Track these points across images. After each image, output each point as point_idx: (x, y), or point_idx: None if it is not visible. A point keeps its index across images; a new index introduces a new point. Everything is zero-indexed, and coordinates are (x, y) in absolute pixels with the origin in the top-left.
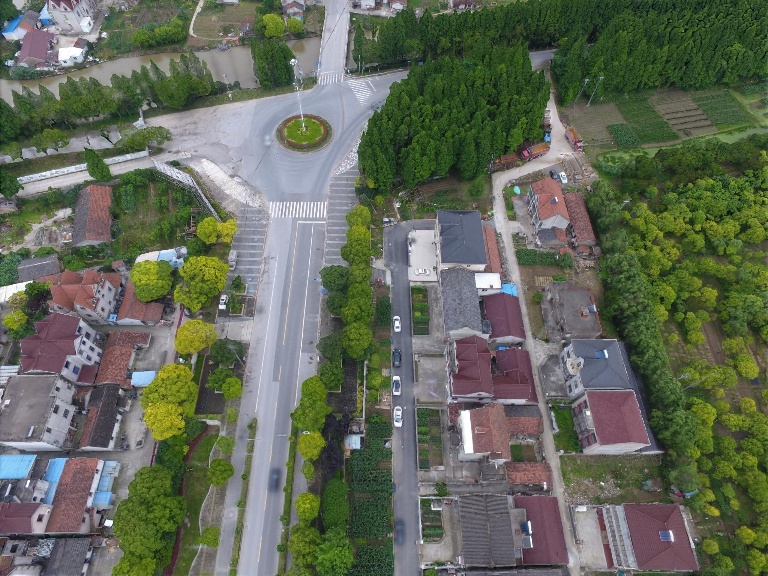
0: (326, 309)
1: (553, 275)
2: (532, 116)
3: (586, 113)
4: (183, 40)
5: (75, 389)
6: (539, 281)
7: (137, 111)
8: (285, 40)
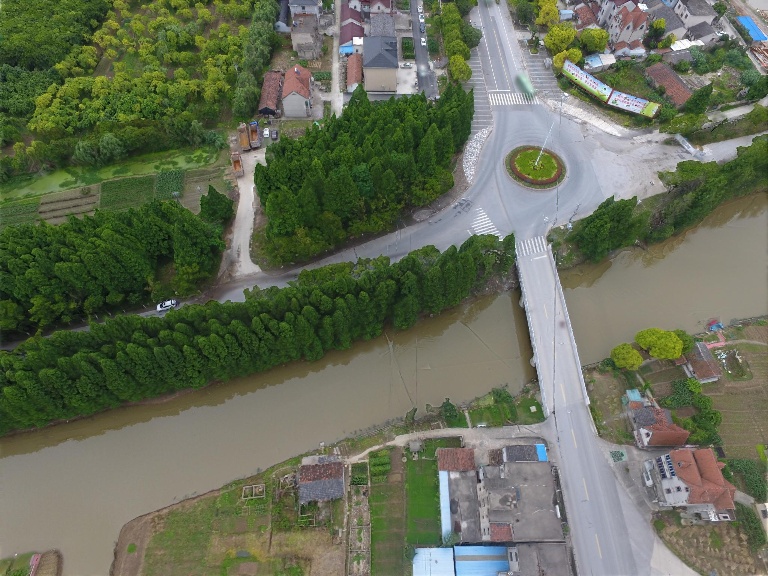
0: None
1: (306, 68)
2: None
3: None
4: None
5: (599, 5)
6: (318, 64)
7: None
8: None
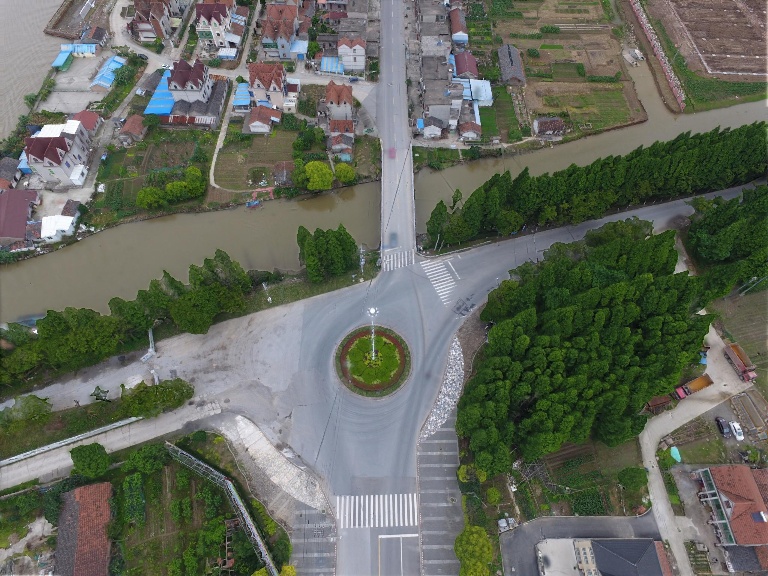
0: None
1: None
2: (694, 348)
3: (740, 306)
4: (202, 194)
5: None
6: None
7: (145, 333)
8: (332, 189)
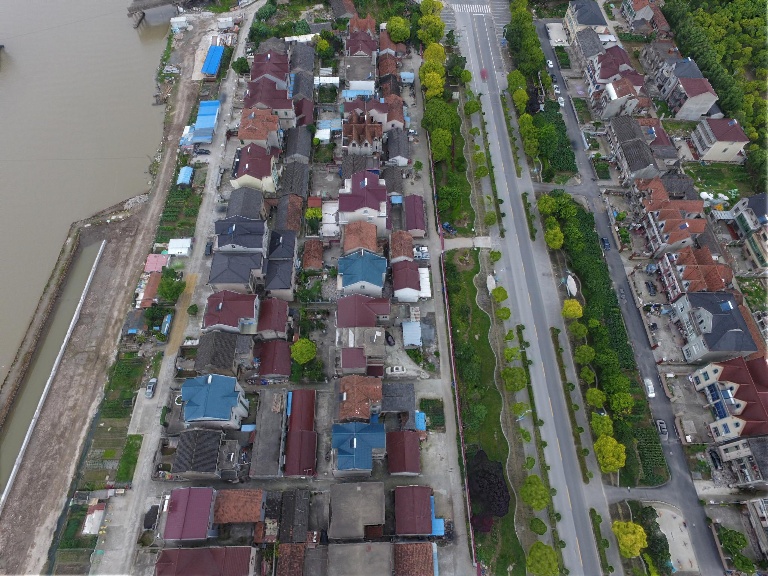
0: (505, 54)
1: None
2: None
3: None
4: None
5: None
6: (635, 49)
7: None
8: None
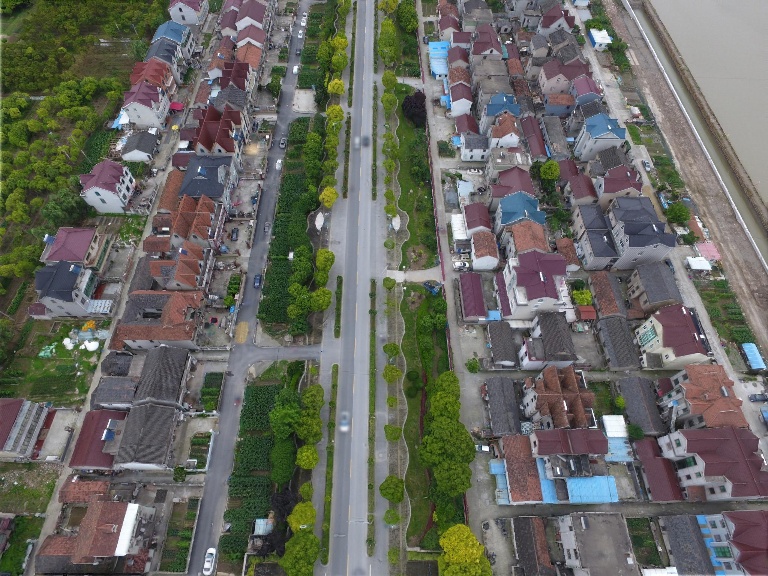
0: None
1: None
2: None
3: None
4: None
5: None
6: None
7: None
8: None
